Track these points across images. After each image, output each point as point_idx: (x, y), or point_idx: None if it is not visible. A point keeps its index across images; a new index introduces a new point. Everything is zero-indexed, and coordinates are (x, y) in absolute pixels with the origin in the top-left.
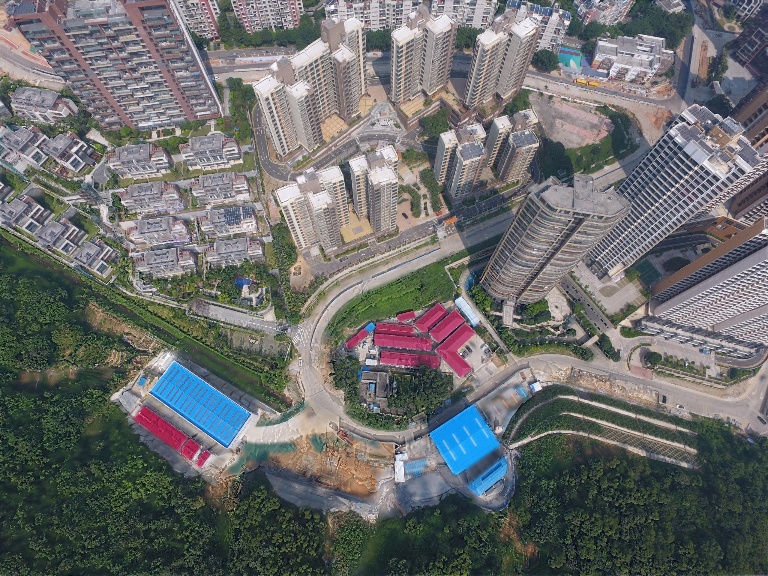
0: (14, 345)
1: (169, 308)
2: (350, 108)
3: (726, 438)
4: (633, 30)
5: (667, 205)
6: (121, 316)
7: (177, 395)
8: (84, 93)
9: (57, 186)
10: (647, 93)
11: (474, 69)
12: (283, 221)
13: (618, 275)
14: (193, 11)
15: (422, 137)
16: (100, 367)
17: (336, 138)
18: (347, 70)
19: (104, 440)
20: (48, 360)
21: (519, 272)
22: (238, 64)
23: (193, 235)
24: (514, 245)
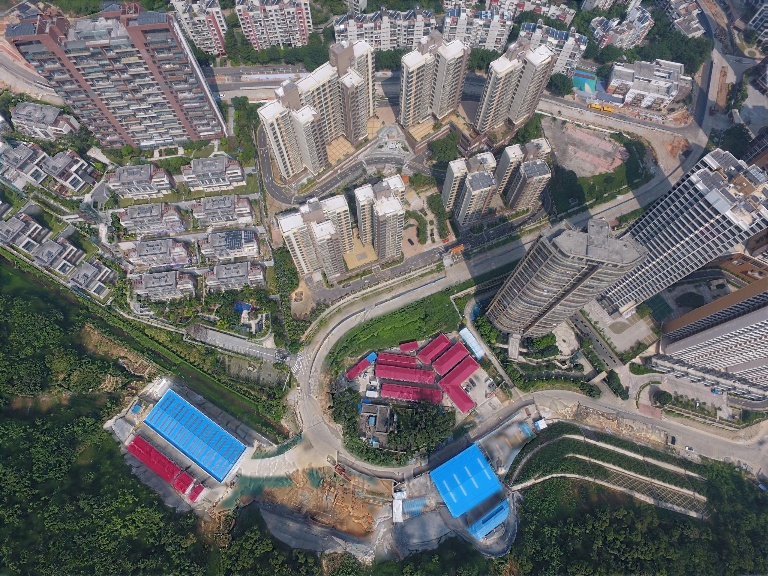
0: (6, 370)
1: (166, 332)
2: (357, 131)
3: (737, 484)
4: (651, 55)
5: (685, 250)
6: (117, 339)
7: (171, 425)
8: (85, 112)
9: (56, 204)
10: (663, 120)
11: (486, 95)
12: (285, 245)
13: (629, 311)
14: (199, 28)
15: (430, 161)
16: (94, 392)
17: (342, 161)
18: (355, 95)
19: (95, 472)
20: (41, 385)
21: (527, 309)
22: (244, 82)
23: (193, 257)
24: (523, 284)
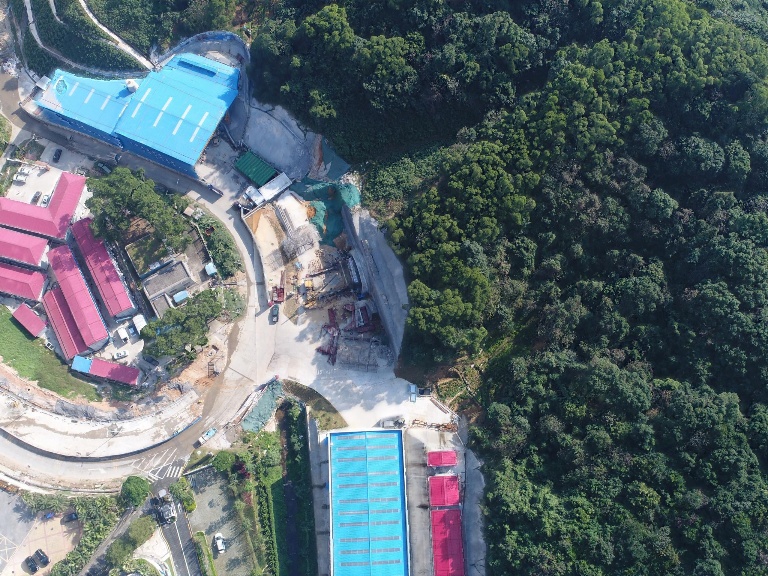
0: None
1: None
2: None
3: None
4: None
5: None
6: None
7: None
8: None
9: None
10: None
11: None
12: None
13: None
14: None
15: None
16: None
17: None
18: None
19: None
20: None
21: None
22: None
23: None
24: None
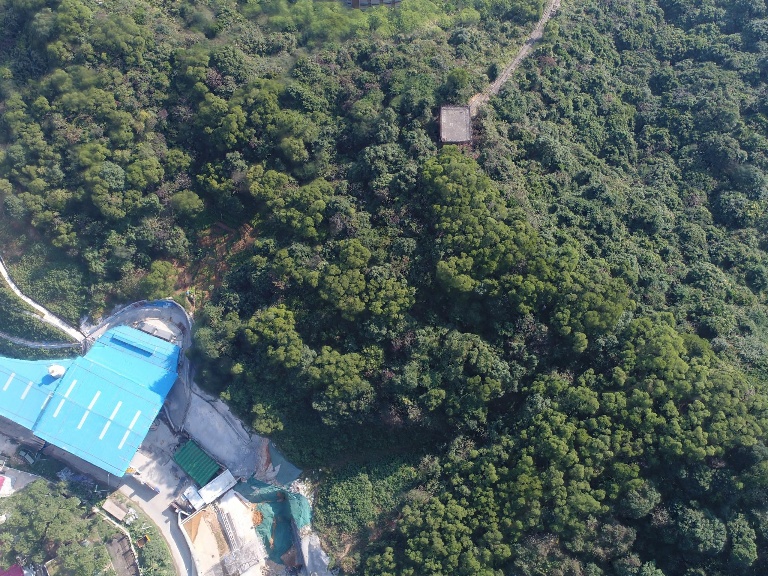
0: None
1: None
2: None
3: None
4: None
5: None
6: None
7: None
8: None
9: None
10: None
11: None
12: None
13: None
14: None
15: None
16: None
17: None
18: None
19: None
20: None
21: None
22: None
23: None
24: None
